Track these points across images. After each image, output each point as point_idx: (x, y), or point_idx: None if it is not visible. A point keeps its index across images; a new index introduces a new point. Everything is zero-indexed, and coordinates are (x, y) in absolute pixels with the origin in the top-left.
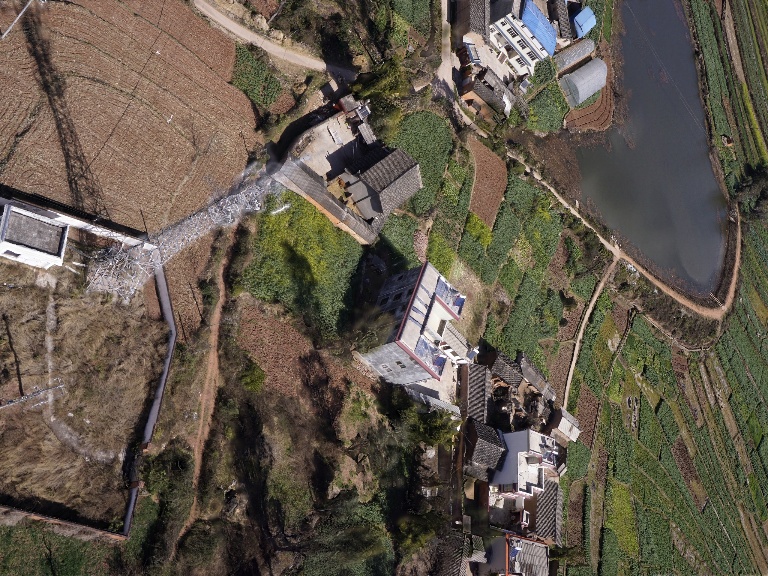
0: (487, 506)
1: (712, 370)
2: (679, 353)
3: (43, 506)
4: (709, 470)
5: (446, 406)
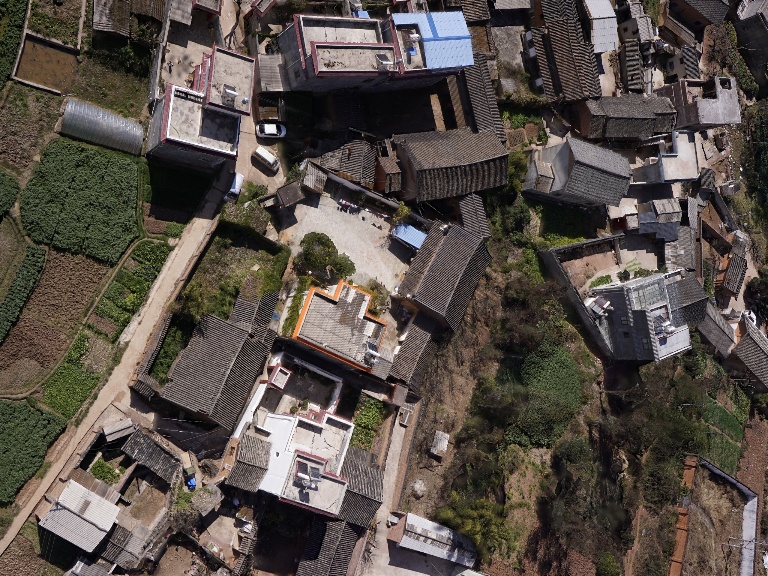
0: None
1: None
2: None
3: (717, 479)
4: None
5: (422, 546)
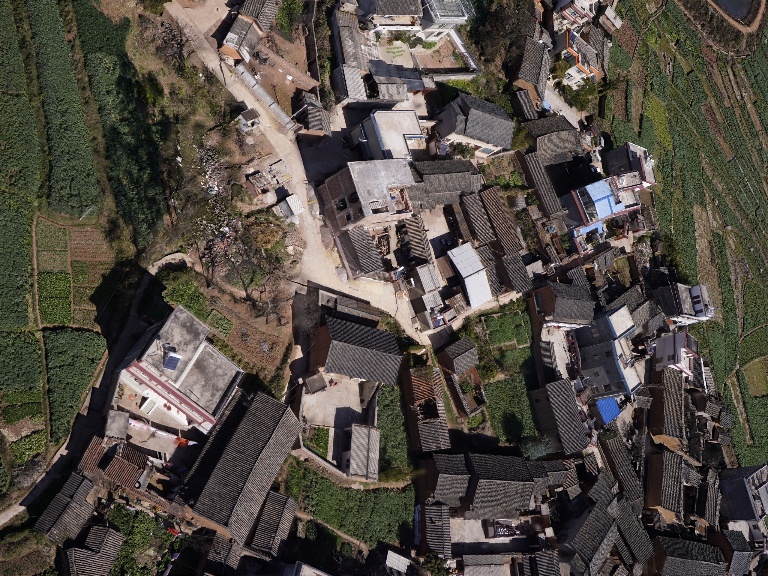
0: (552, 23)
1: (739, 77)
2: (708, 46)
3: None
4: (735, 137)
5: None
